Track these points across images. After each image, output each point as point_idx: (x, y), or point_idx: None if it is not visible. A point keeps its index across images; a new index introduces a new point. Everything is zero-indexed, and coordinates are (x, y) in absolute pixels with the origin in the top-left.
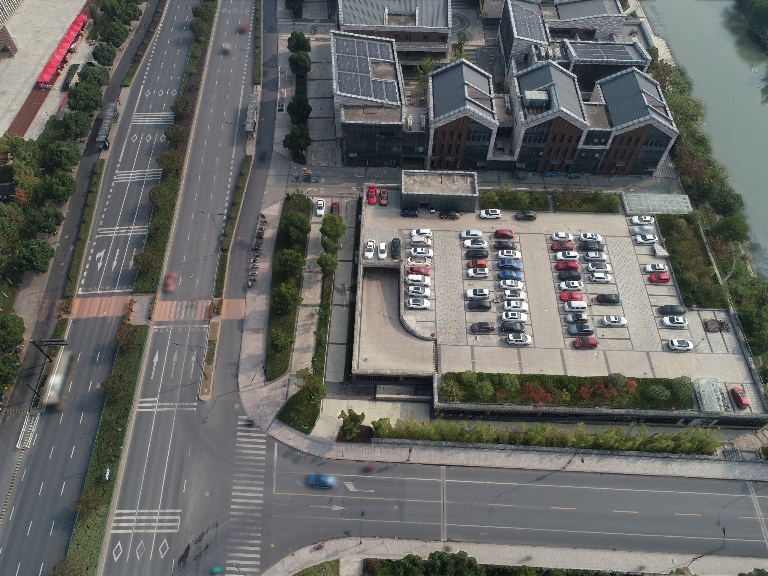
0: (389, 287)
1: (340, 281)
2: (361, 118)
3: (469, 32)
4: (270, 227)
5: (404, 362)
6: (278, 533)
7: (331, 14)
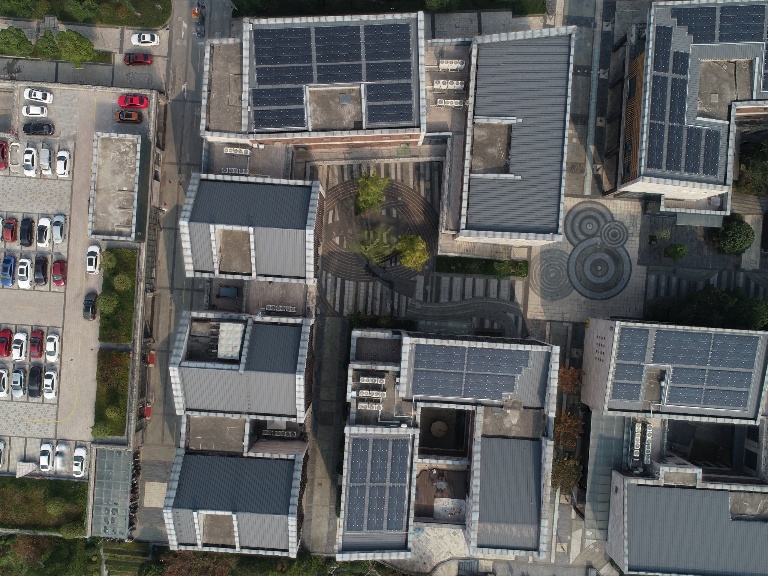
0: (2, 123)
1: (25, 67)
2: (219, 70)
3: (567, 295)
4: None
5: None
6: None
7: (617, 48)
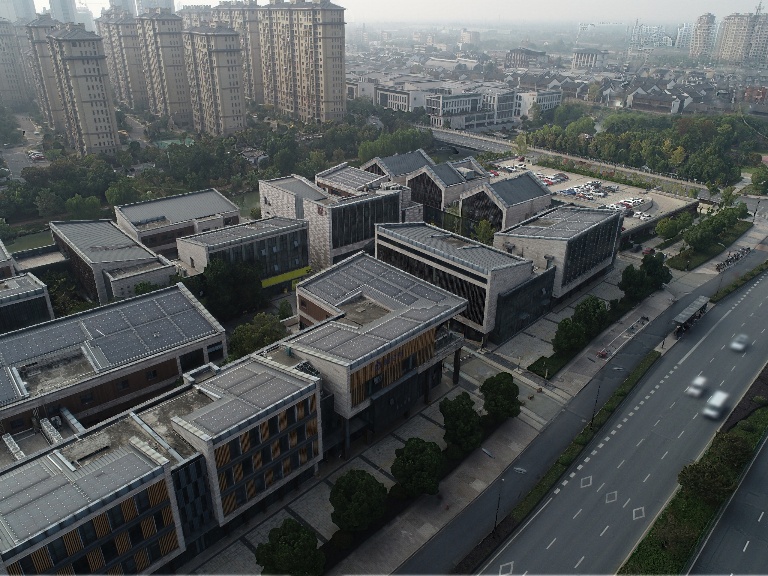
0: None
1: None
2: None
3: None
4: (715, 265)
5: (664, 197)
6: (765, 202)
7: (455, 375)
